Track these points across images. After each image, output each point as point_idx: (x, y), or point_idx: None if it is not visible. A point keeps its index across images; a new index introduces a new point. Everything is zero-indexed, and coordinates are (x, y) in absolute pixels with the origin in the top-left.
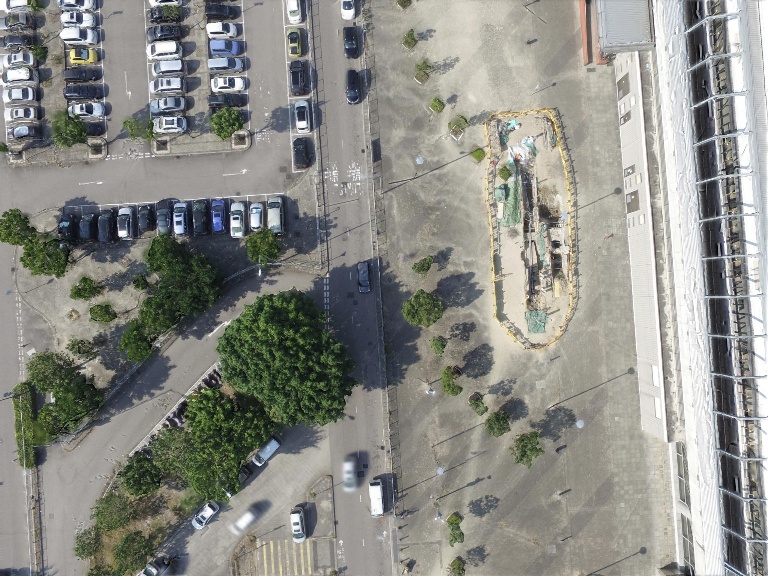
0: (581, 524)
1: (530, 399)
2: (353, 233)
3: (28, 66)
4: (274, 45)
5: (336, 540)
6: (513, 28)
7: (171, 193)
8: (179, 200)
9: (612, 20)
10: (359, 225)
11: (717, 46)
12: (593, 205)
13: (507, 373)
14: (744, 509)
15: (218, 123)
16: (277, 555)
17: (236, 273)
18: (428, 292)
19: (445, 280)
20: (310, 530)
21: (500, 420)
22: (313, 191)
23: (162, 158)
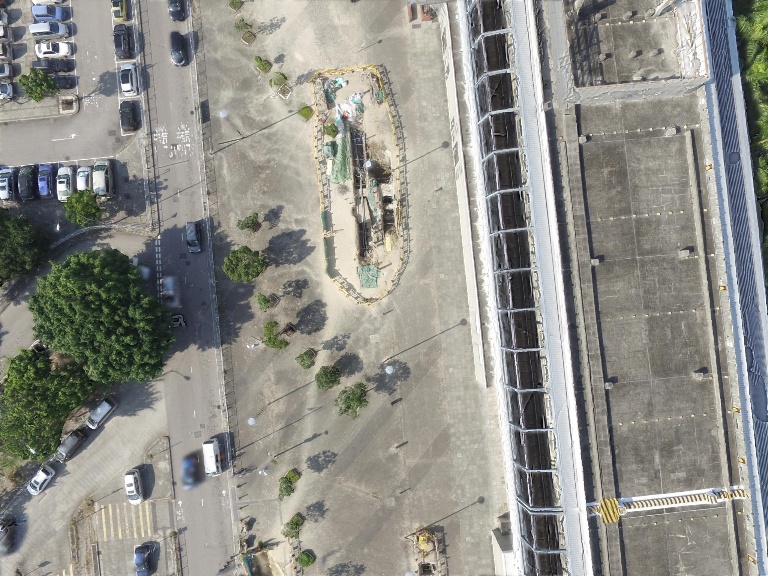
0: (419, 476)
1: (364, 353)
2: (184, 194)
3: None
4: (100, 10)
5: (175, 501)
6: None
7: None
8: (8, 166)
9: None
10: (190, 186)
11: None
12: (421, 159)
13: (341, 328)
14: (549, 447)
15: (26, 84)
16: (116, 518)
17: (65, 237)
18: (260, 250)
19: (277, 238)
20: (148, 492)
21: (327, 373)
22: (142, 153)
23: None
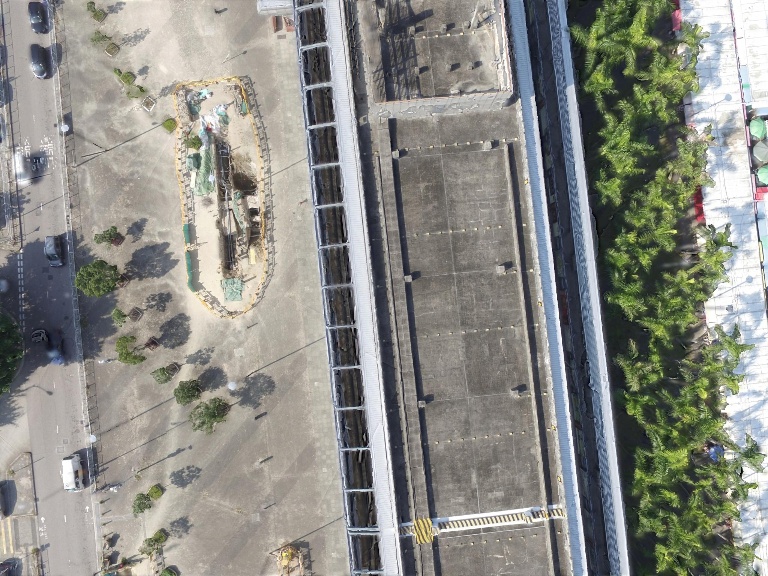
0: (284, 491)
1: (229, 367)
2: (47, 208)
3: None
4: None
5: (38, 517)
6: None
7: None
8: None
9: None
10: (53, 199)
11: None
12: (286, 171)
13: (205, 342)
14: None
15: None
16: None
17: None
18: (123, 264)
19: (140, 251)
20: (10, 508)
21: (185, 388)
22: (3, 167)
23: None
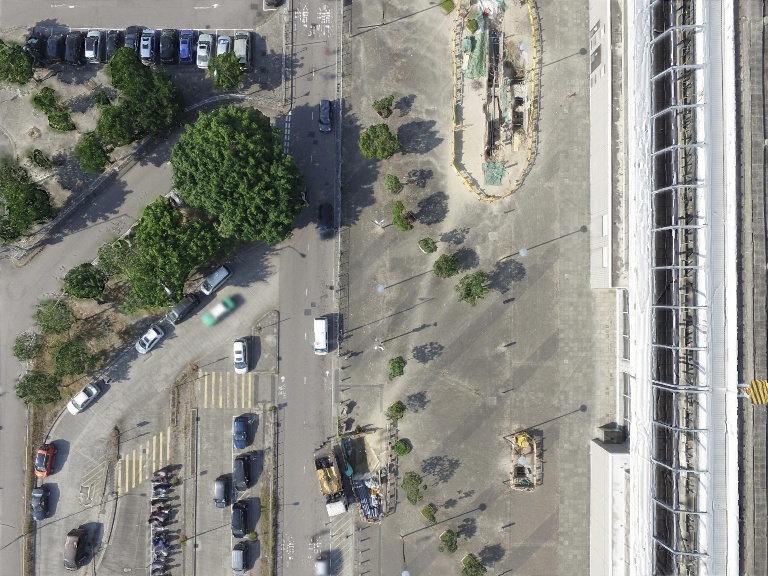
0: (523, 378)
1: (482, 250)
2: (318, 74)
3: None
4: None
5: (278, 376)
6: None
7: (142, 21)
8: (149, 29)
9: None
10: (325, 66)
11: None
12: (558, 64)
13: (461, 222)
14: (679, 344)
15: None
16: (218, 387)
17: (199, 102)
18: None
19: (406, 126)
20: (253, 364)
21: (448, 261)
22: (282, 29)
23: None
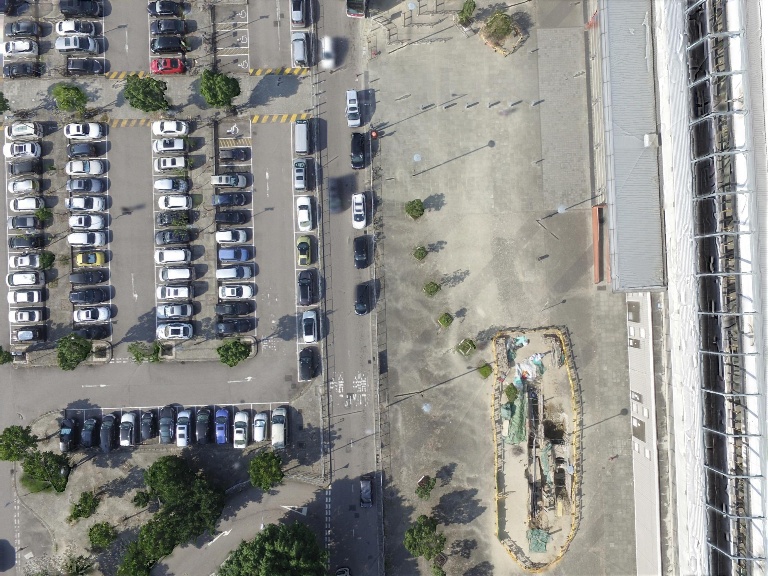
0: None
1: None
2: (357, 445)
3: (34, 271)
4: (283, 251)
5: None
6: (525, 242)
7: (175, 399)
8: (183, 406)
9: (625, 261)
10: (363, 437)
11: (730, 308)
12: (599, 425)
13: None
14: None
15: (225, 356)
16: None
17: (238, 485)
18: (430, 507)
19: (448, 496)
20: None
21: None
22: (318, 402)
23: (167, 363)
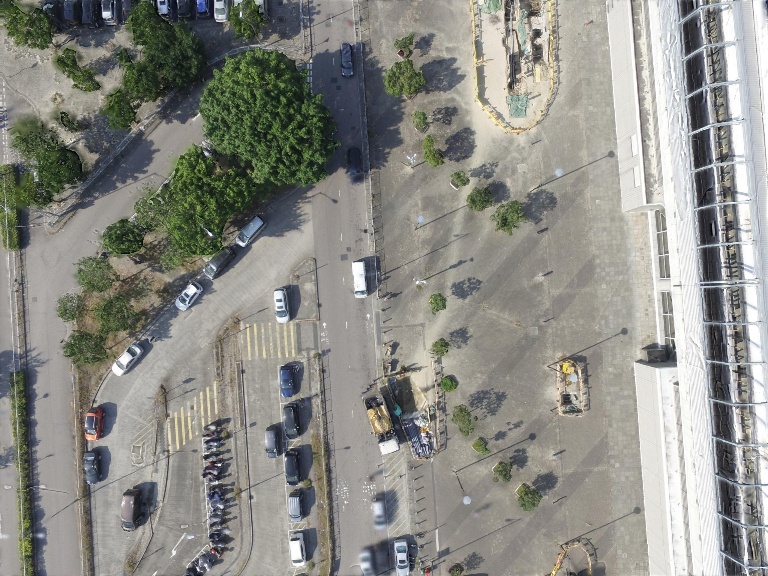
0: (563, 306)
1: (512, 182)
2: (336, 20)
3: None
4: None
5: (320, 323)
6: None
7: None
8: None
9: None
10: (342, 12)
11: None
12: None
13: (489, 157)
14: (720, 250)
15: None
16: (261, 338)
17: (220, 55)
18: None
19: (427, 65)
20: (294, 312)
21: (481, 193)
22: None
23: None
